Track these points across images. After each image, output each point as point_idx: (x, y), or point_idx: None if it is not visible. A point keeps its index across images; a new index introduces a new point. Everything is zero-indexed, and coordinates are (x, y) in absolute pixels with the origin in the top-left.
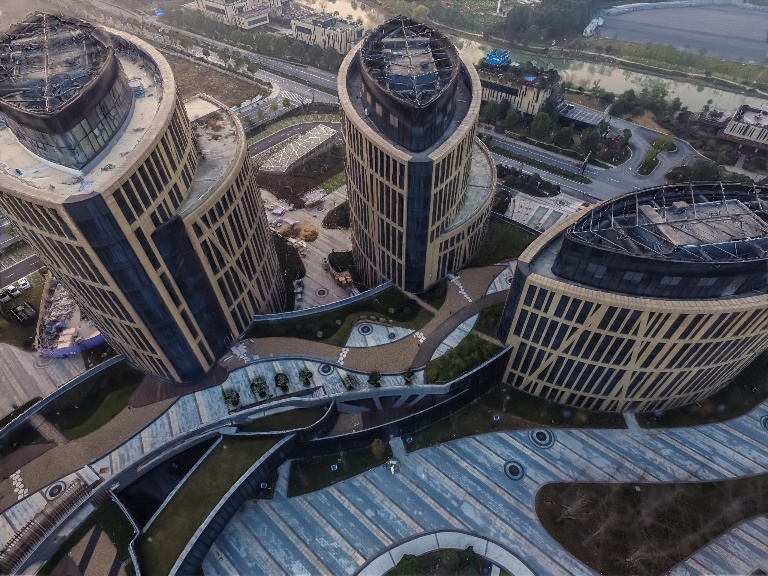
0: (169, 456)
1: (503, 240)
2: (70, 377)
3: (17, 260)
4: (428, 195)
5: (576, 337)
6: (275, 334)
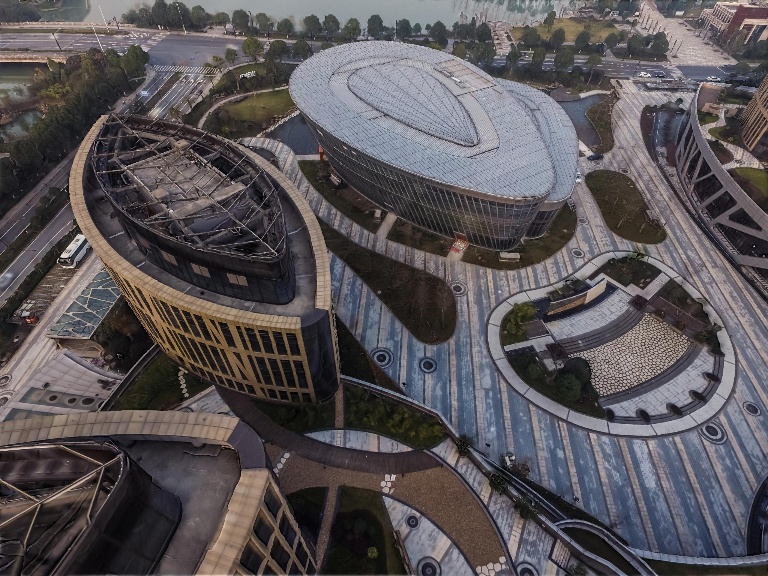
0: None
1: None
2: None
3: None
4: None
5: None
6: None
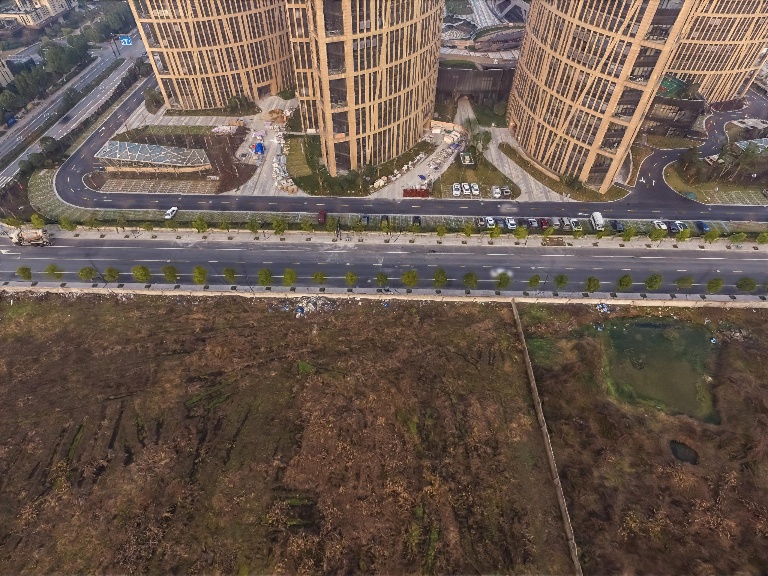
0: None
1: None
2: (462, 125)
3: (451, 219)
4: None
5: None
6: None
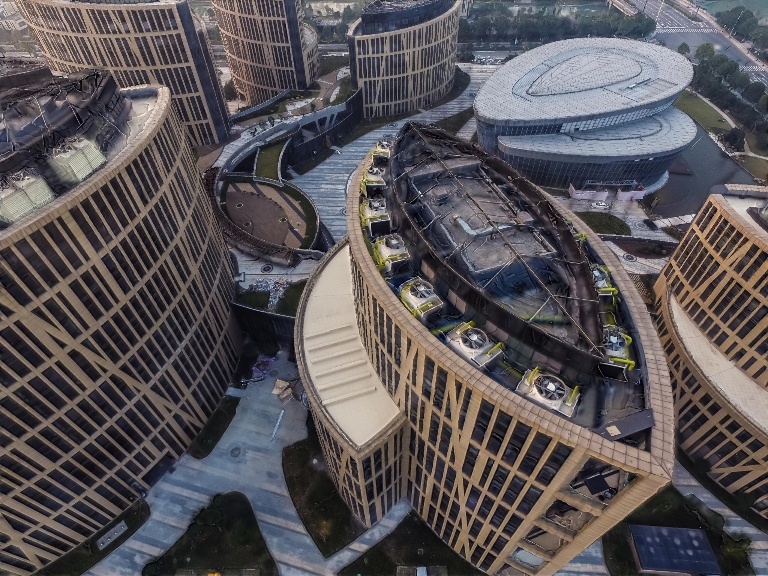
0: (240, 160)
1: (330, 63)
2: None
3: None
4: (296, 18)
5: (384, 63)
6: (249, 118)
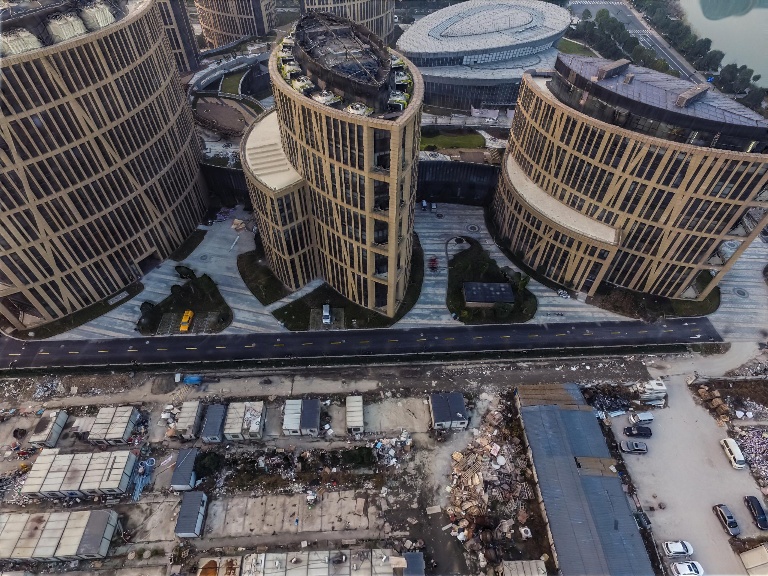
0: (208, 83)
1: (286, 17)
2: None
3: None
4: None
5: None
6: (215, 55)
